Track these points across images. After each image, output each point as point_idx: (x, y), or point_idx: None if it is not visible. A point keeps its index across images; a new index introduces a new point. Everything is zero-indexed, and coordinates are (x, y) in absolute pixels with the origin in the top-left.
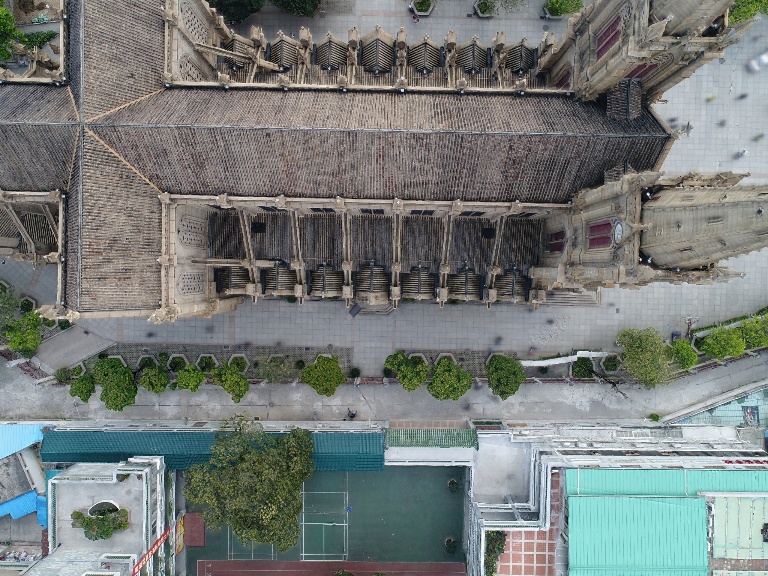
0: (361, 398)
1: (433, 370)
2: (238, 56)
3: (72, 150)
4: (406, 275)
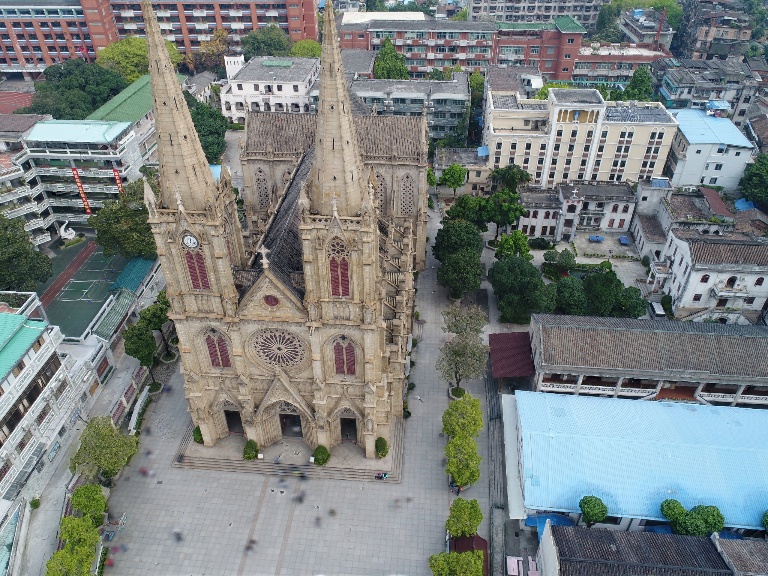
0: None
1: None
2: None
3: None
4: None
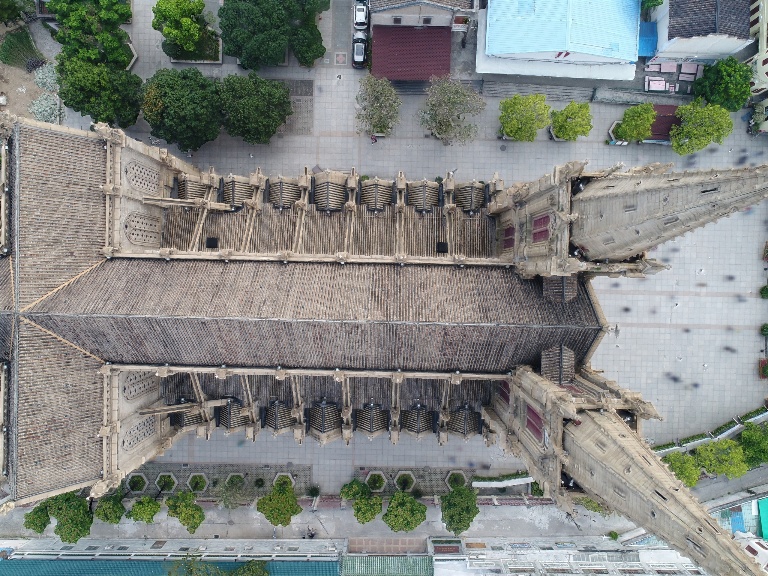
0: (320, 516)
1: (392, 487)
2: (188, 203)
3: (10, 331)
4: (359, 410)
